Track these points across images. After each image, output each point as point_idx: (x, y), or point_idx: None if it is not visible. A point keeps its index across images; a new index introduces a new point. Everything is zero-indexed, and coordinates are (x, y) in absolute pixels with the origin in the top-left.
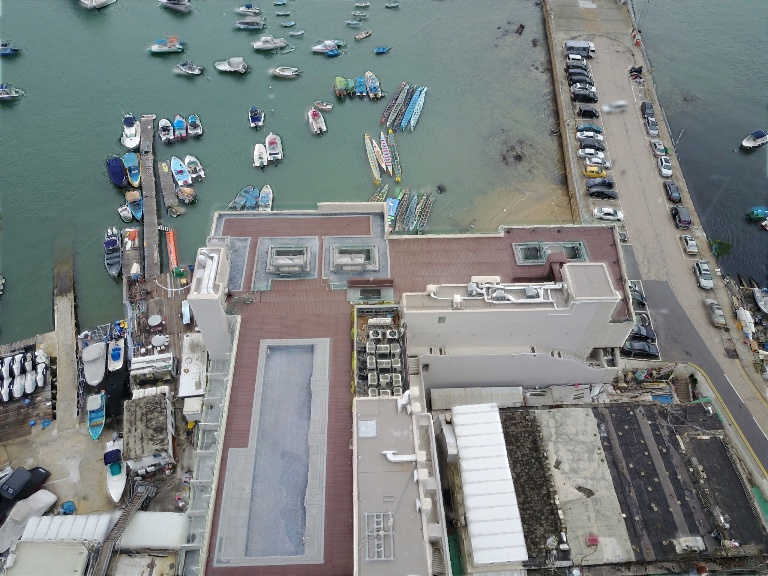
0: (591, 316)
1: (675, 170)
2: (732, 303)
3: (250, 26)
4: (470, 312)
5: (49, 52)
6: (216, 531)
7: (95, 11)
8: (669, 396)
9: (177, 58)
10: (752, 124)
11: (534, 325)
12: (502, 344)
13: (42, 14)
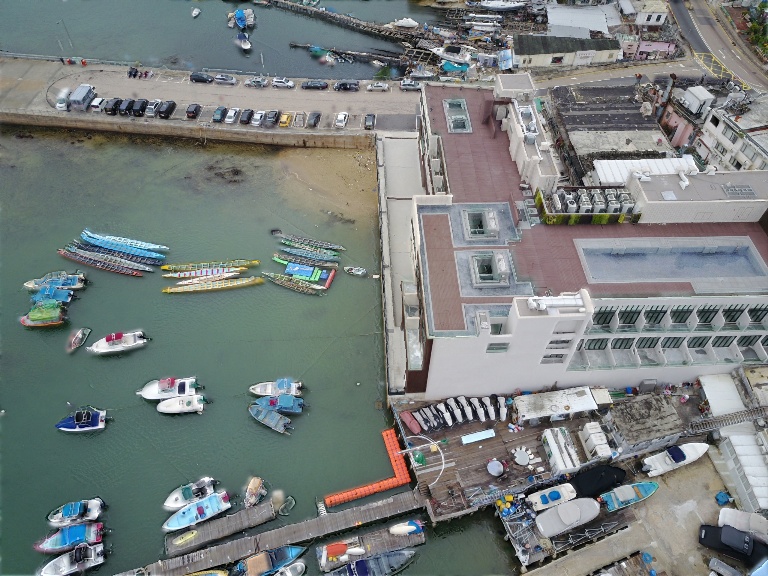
0: None
1: None
2: None
3: None
4: None
5: None
6: (760, 293)
7: None
8: None
9: None
10: (223, 38)
11: None
12: None
13: None
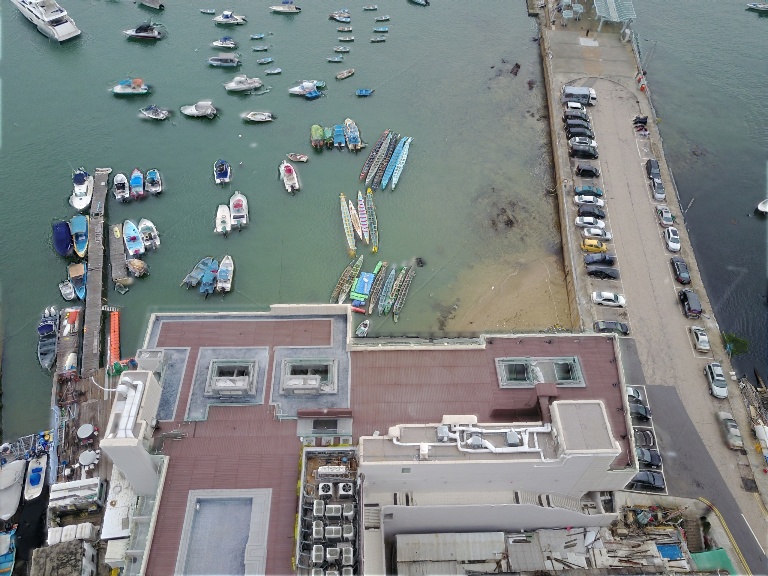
0: (585, 466)
1: (684, 243)
2: (749, 416)
3: (223, 63)
4: (440, 464)
5: (4, 91)
6: None
7: (57, 44)
8: (677, 545)
9: (141, 100)
10: None
11: (517, 474)
12: (480, 489)
13: (1, 46)
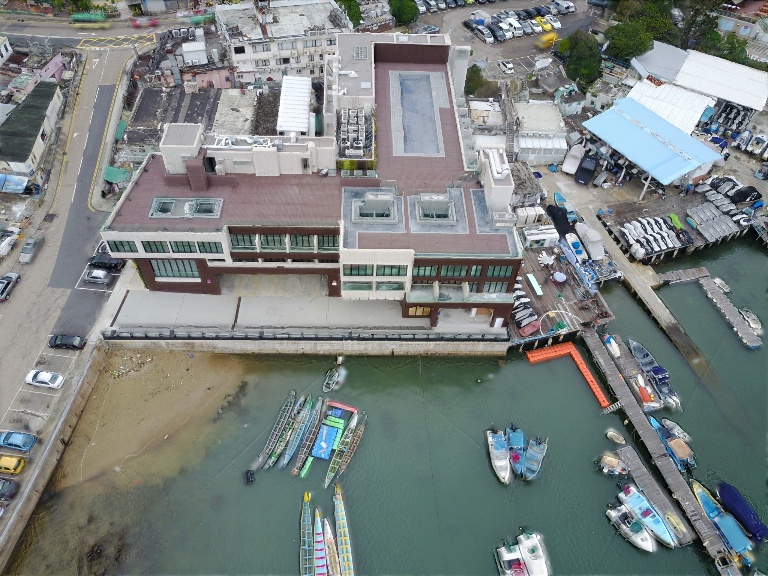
0: None
1: None
2: (2, 262)
3: None
4: None
5: None
6: (447, 80)
7: None
8: None
9: None
10: None
11: None
12: None
13: None
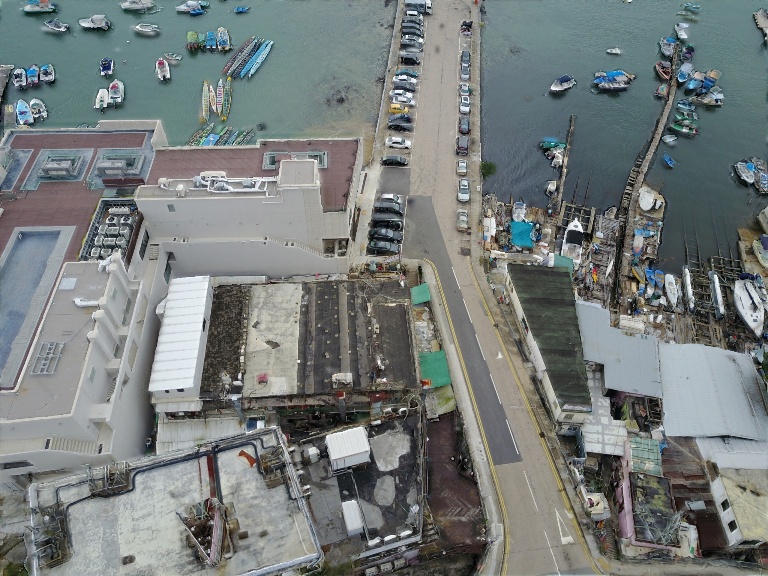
0: (302, 204)
1: (474, 108)
2: (482, 213)
3: None
4: (192, 199)
5: None
6: None
7: None
8: None
9: (47, 17)
10: (564, 71)
11: (256, 214)
12: (238, 234)
13: None
